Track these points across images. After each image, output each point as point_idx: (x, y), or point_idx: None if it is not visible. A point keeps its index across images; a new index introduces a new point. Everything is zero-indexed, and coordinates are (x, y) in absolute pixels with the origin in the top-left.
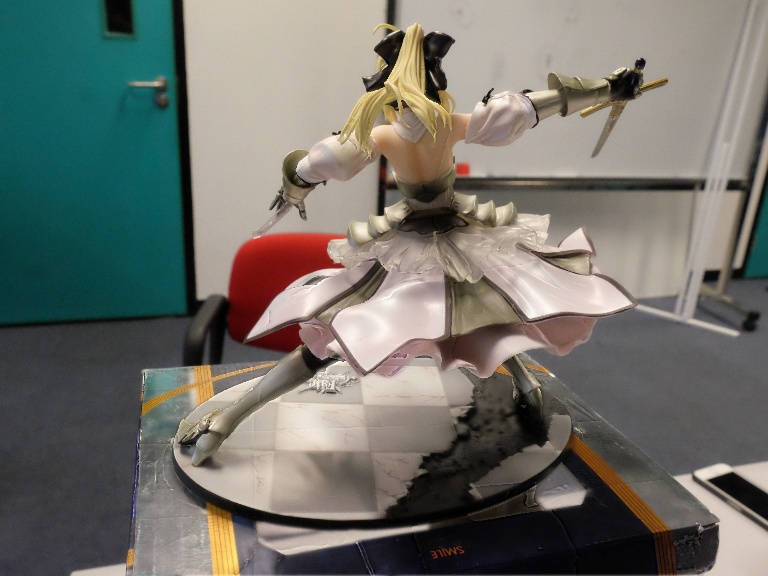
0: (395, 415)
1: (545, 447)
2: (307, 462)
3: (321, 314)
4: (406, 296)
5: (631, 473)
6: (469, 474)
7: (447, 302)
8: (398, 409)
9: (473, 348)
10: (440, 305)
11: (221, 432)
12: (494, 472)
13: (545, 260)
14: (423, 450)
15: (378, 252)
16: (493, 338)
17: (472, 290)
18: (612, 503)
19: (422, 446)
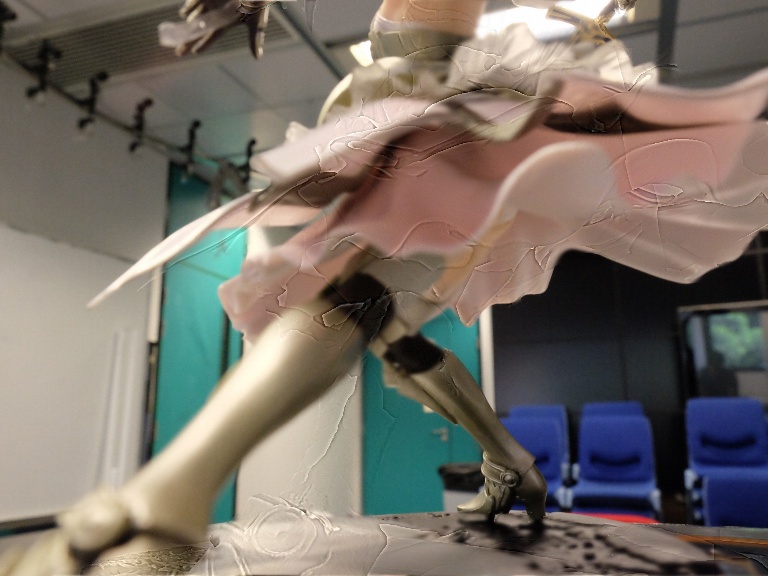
0: (401, 560)
1: (620, 526)
2: None
3: None
4: None
5: (696, 530)
6: (652, 568)
7: None
8: (384, 556)
9: None
10: None
11: (369, 536)
12: (669, 550)
13: None
14: (549, 568)
15: (597, 25)
16: None
17: None
18: (763, 548)
19: (531, 569)
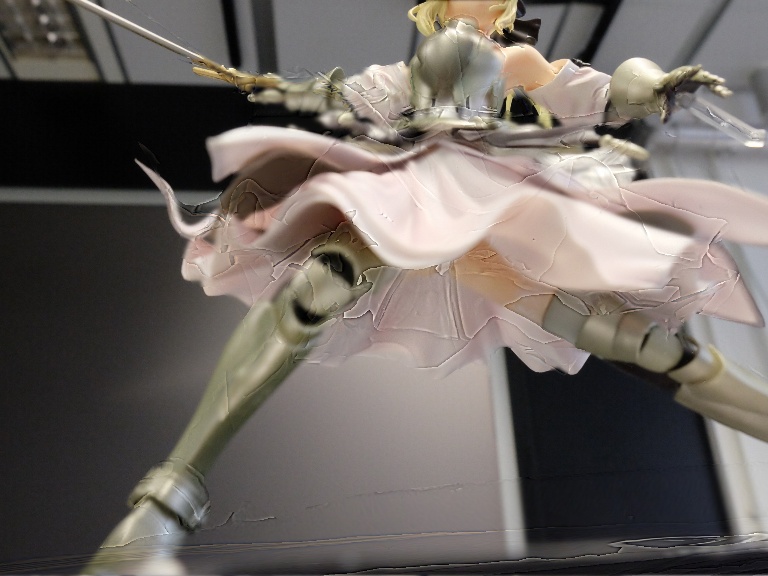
0: (574, 572)
1: None
2: (738, 575)
3: (619, 297)
4: (502, 289)
5: None
6: None
7: (456, 300)
8: (567, 568)
9: (431, 353)
10: (464, 303)
11: None
12: None
13: (304, 242)
14: None
15: None
16: (410, 344)
17: (423, 286)
18: None
19: None
